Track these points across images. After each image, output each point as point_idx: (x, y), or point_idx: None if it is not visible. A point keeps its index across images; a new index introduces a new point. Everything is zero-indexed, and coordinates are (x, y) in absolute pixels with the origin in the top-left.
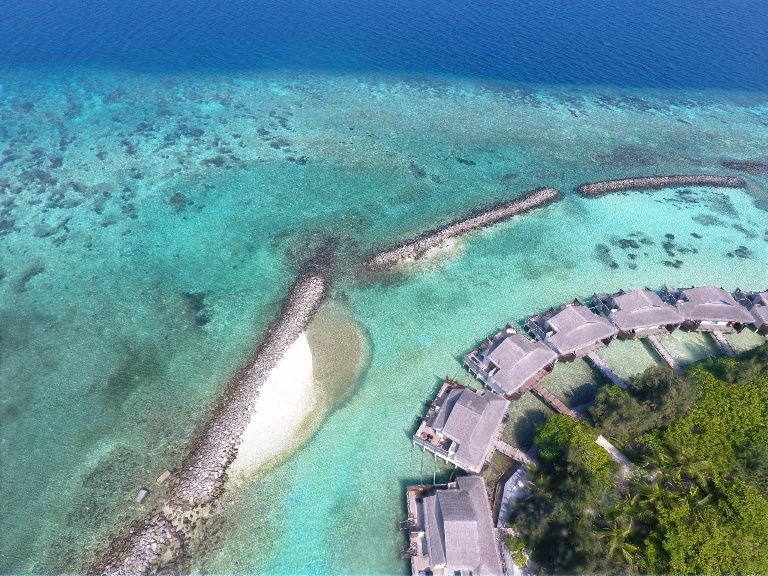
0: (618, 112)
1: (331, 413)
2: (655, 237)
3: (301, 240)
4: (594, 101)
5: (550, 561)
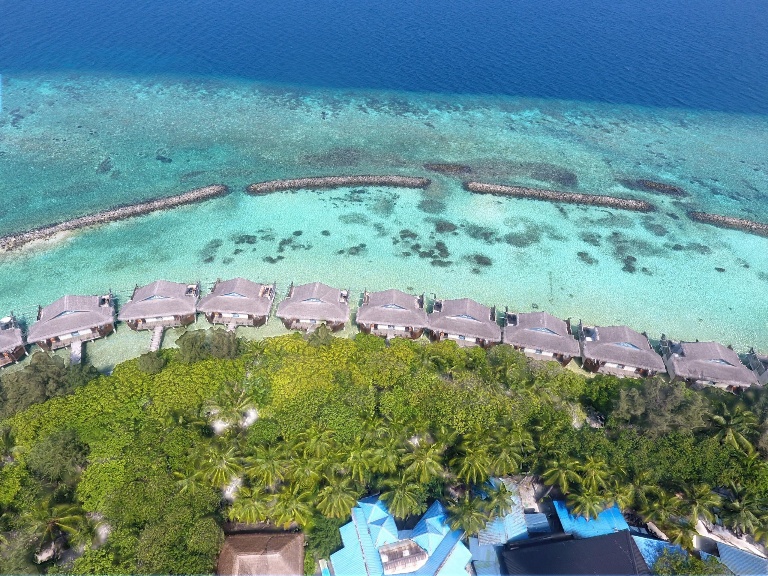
0: (371, 115)
1: None
2: (281, 233)
3: None
4: (358, 104)
5: None
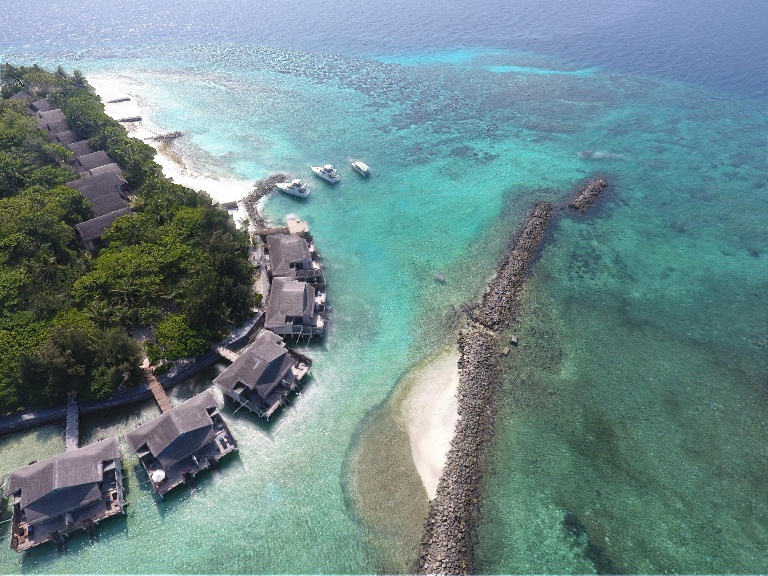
0: None
1: (385, 400)
2: None
3: None
4: None
5: (242, 280)
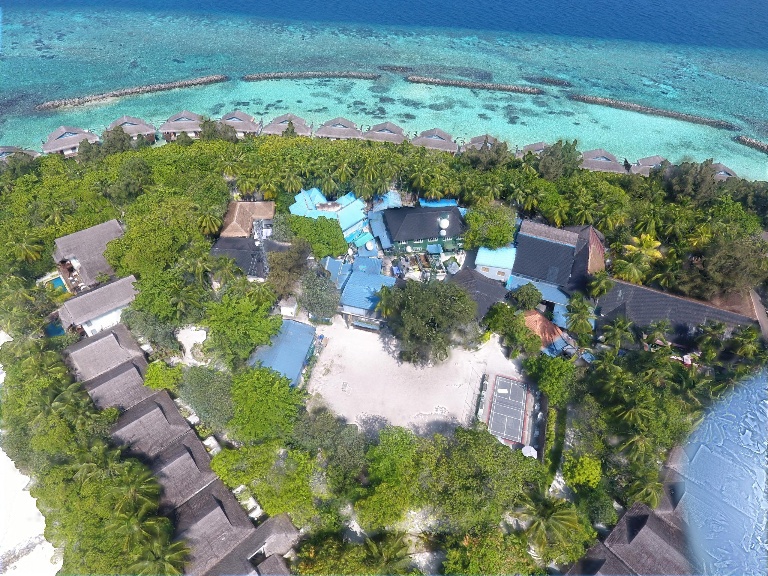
0: (341, 38)
1: None
2: (267, 101)
3: (3, 95)
4: (331, 31)
5: None
